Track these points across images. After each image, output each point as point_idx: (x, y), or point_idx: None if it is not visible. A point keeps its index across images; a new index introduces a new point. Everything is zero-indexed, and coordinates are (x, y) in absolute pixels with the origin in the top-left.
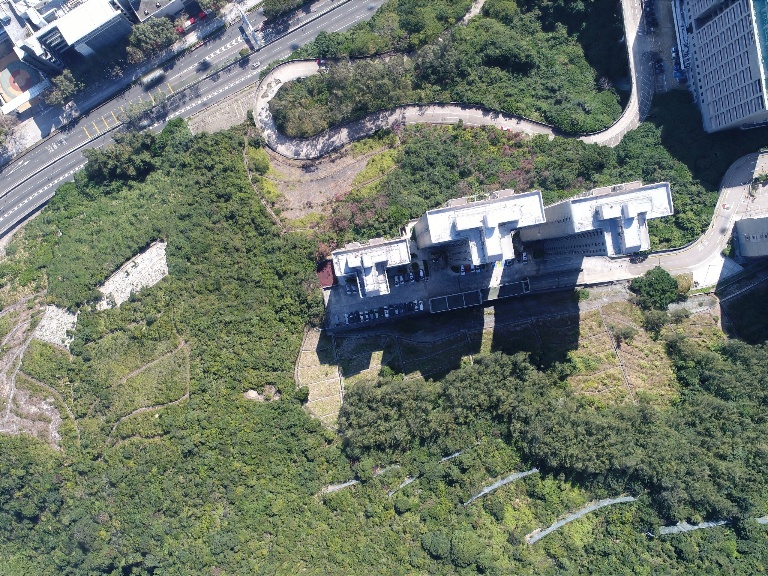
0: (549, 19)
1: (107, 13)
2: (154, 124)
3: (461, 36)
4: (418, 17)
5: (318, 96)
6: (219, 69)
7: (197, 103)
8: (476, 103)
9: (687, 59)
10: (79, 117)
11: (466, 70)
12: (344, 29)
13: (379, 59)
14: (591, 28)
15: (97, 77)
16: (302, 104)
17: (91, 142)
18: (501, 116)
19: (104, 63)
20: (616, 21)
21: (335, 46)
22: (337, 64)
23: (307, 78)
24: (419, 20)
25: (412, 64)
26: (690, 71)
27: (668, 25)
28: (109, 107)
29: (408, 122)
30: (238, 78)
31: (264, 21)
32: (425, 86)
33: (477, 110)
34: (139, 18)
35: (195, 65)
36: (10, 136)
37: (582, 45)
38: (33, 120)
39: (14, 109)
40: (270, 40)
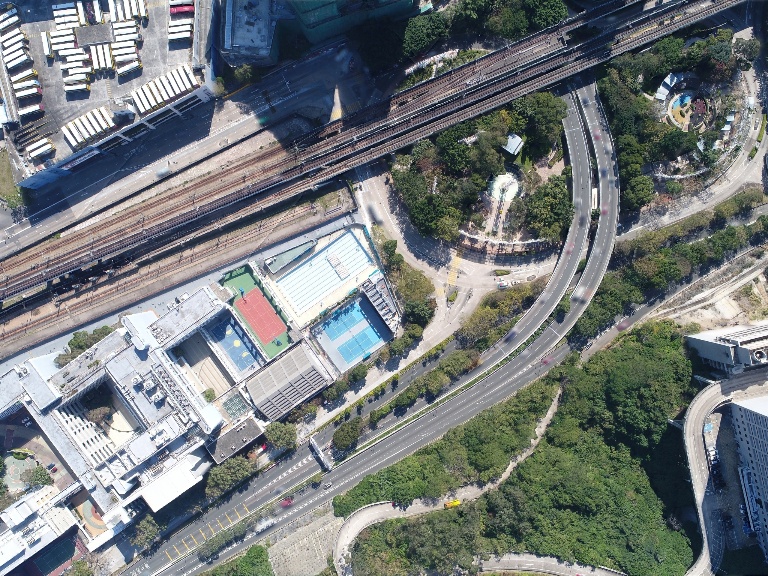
0: (611, 436)
1: (189, 480)
2: (233, 545)
3: (530, 478)
4: (487, 457)
5: (397, 548)
6: (293, 492)
7: (273, 523)
8: (551, 554)
9: (757, 524)
10: (160, 542)
11: (540, 526)
12: (411, 447)
13: (450, 491)
14: (656, 463)
15: (178, 515)
16: (382, 559)
17: (173, 565)
18: (576, 564)
19: (185, 506)
20: (681, 461)
21: (409, 493)
22: (410, 502)
23: (384, 525)
24: (488, 462)
25: (484, 503)
26: (760, 534)
27: (735, 483)
28: (188, 530)
29: (485, 568)
30: (311, 498)
31: (333, 440)
32: (500, 537)
33: (552, 558)
34: (216, 461)
35: (269, 485)
36: (95, 563)
37: (647, 472)
38: (116, 547)
39: (99, 546)
40: (339, 457)
